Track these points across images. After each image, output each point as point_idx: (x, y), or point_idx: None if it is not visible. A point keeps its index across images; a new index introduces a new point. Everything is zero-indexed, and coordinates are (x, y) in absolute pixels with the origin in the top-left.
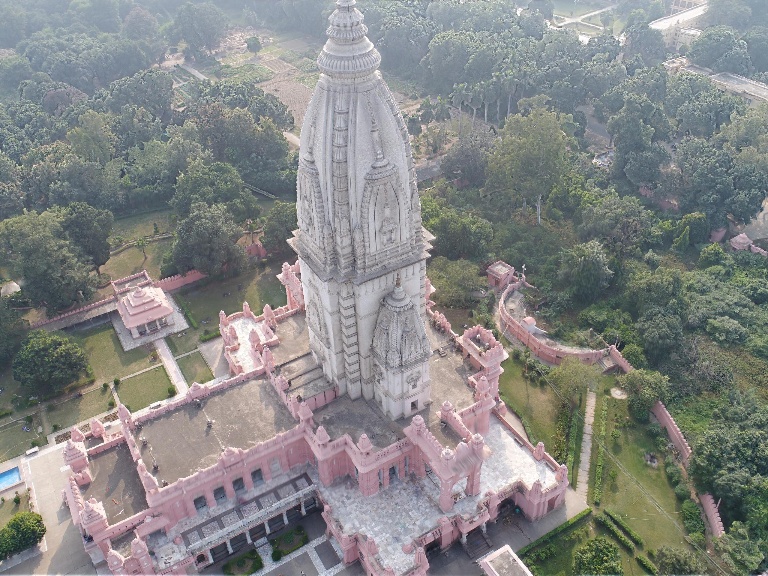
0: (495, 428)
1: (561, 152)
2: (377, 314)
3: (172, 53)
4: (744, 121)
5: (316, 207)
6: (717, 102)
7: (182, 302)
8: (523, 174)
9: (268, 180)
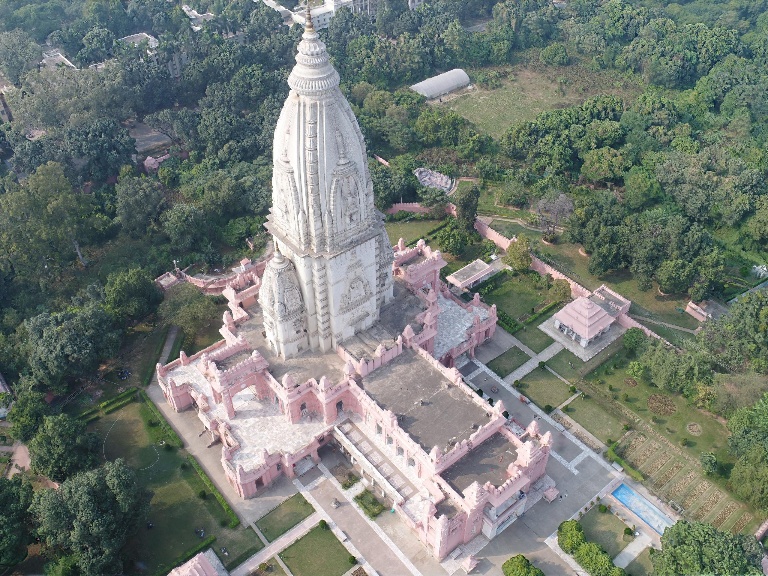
0: None
1: None
2: None
3: None
4: None
5: (362, 189)
6: None
7: (162, 572)
8: None
9: None
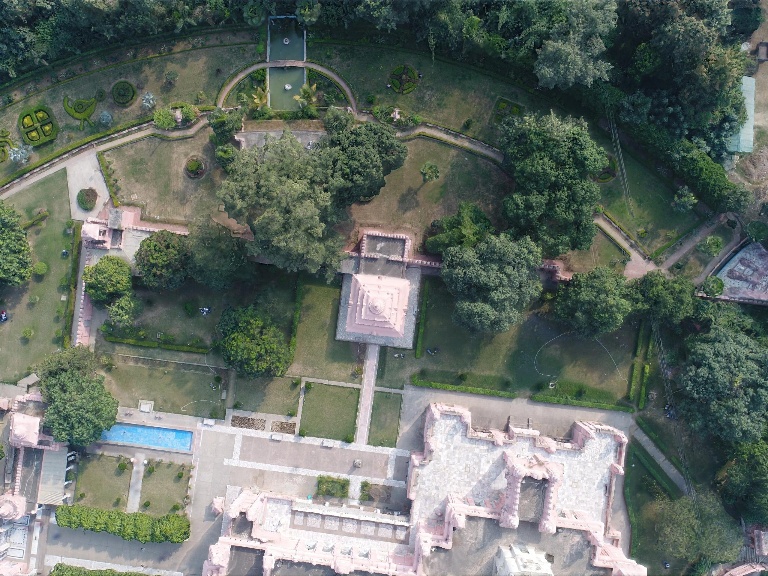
0: None
1: None
2: None
3: None
4: None
5: None
6: None
7: (425, 303)
8: None
9: (655, 145)
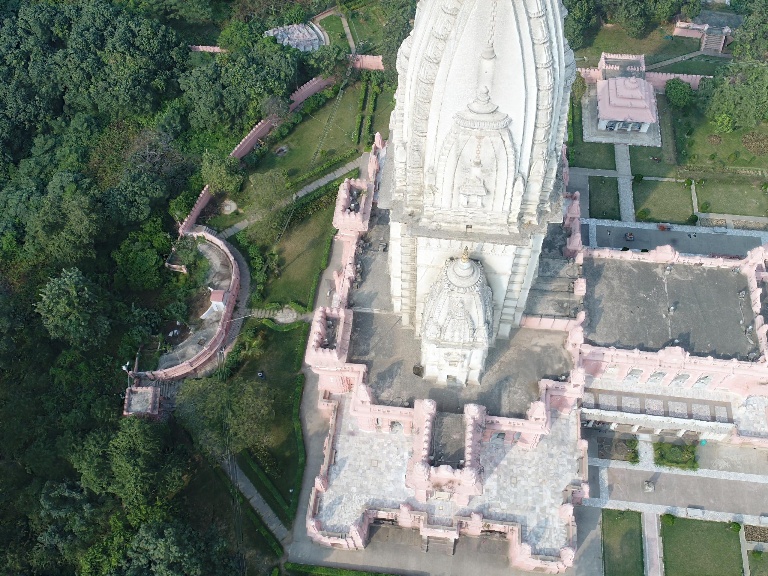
0: None
1: None
2: None
3: None
4: None
5: None
6: None
7: None
8: None
9: None
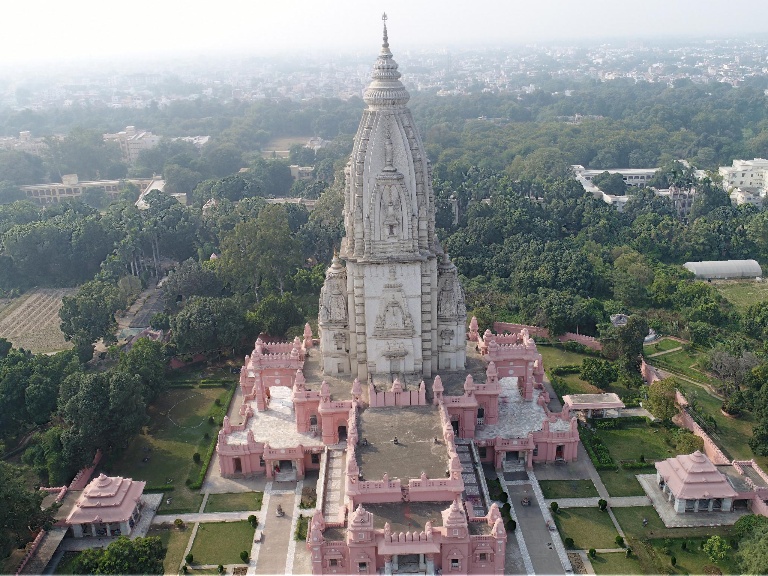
0: None
1: None
2: None
3: None
4: (331, 201)
5: (407, 204)
6: (288, 206)
7: None
8: None
9: None
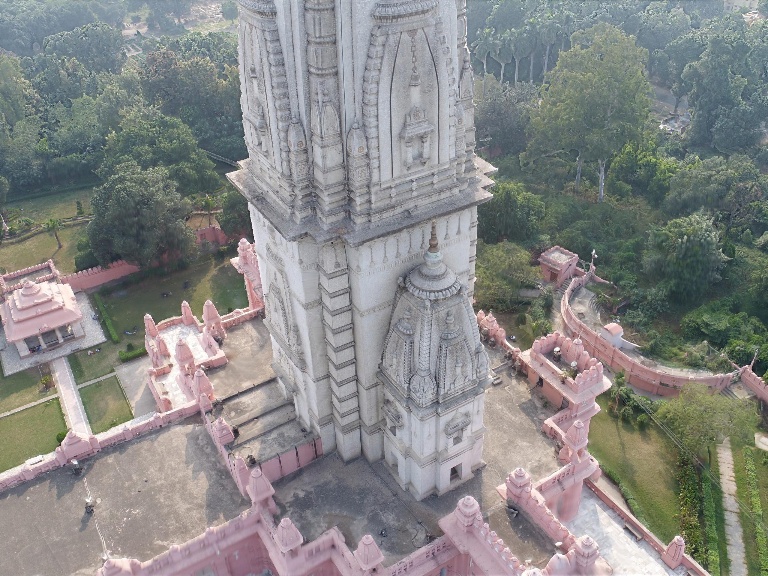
0: (587, 506)
1: (638, 95)
2: (391, 307)
3: (134, 22)
4: None
5: (272, 86)
6: None
7: (100, 305)
8: (584, 128)
9: (234, 147)
